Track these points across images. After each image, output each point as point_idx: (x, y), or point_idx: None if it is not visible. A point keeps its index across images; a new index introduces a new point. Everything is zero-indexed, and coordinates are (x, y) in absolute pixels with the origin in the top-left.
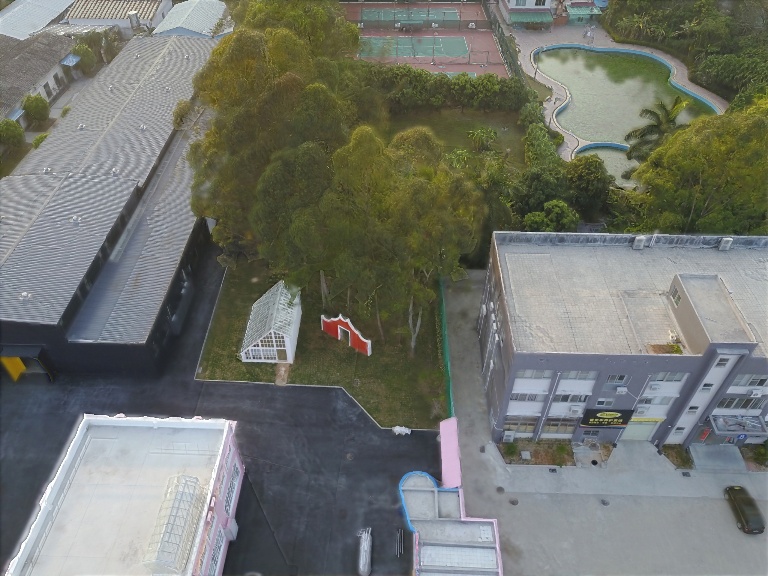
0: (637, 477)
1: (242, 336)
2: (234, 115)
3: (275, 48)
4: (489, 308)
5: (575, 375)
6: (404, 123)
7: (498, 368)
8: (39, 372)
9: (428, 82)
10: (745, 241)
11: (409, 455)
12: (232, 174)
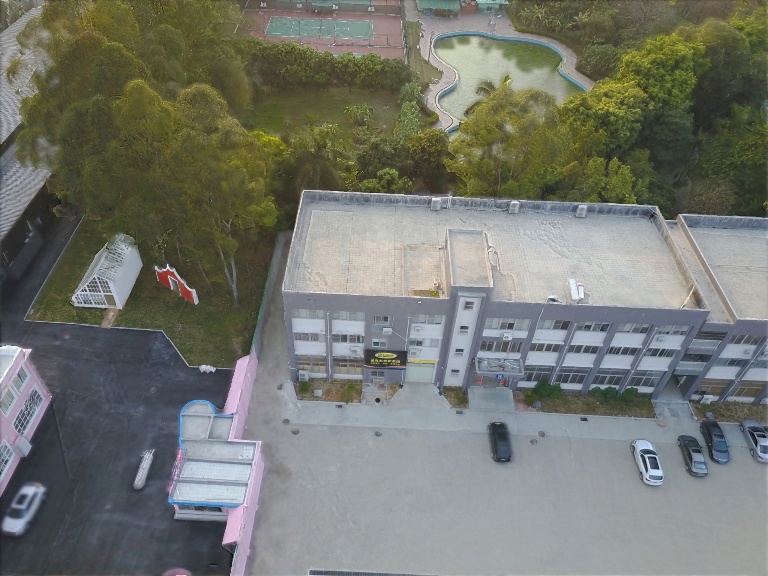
0: (414, 413)
1: None
2: (46, 70)
3: (99, 11)
4: None
5: (345, 316)
6: (292, 99)
7: None
8: None
9: (312, 59)
10: (533, 205)
11: (208, 390)
12: None
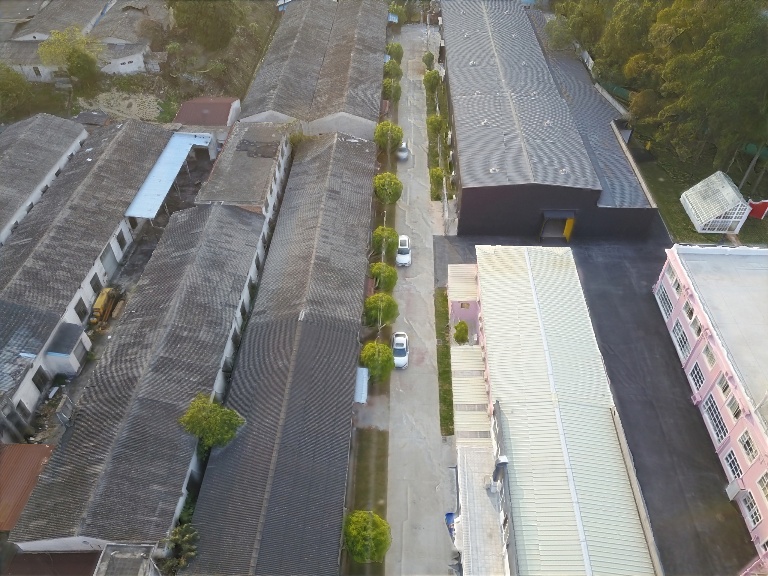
0: None
1: (684, 216)
2: (754, 27)
3: None
4: None
5: None
6: None
7: None
8: (552, 236)
9: None
10: None
11: None
12: (751, 72)
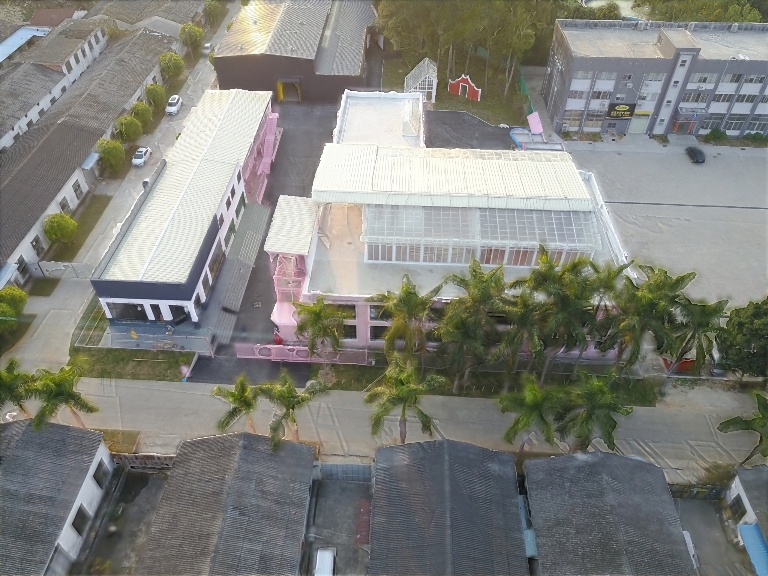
0: (637, 146)
1: (401, 92)
2: None
3: None
4: (552, 67)
5: (605, 77)
6: None
7: (560, 86)
8: (291, 100)
9: None
10: (702, 26)
11: None
12: None
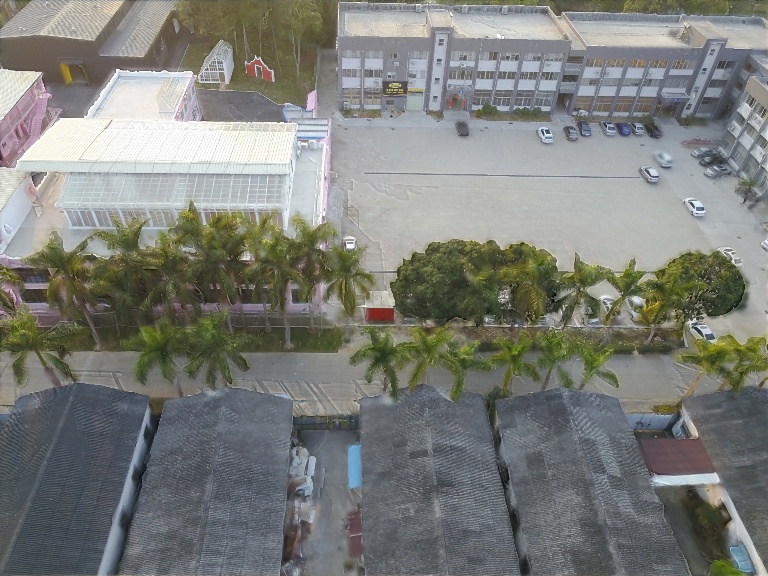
0: (413, 122)
1: None
2: None
3: None
4: None
5: (372, 55)
6: None
7: None
8: (80, 82)
9: None
10: (476, 8)
11: None
12: None
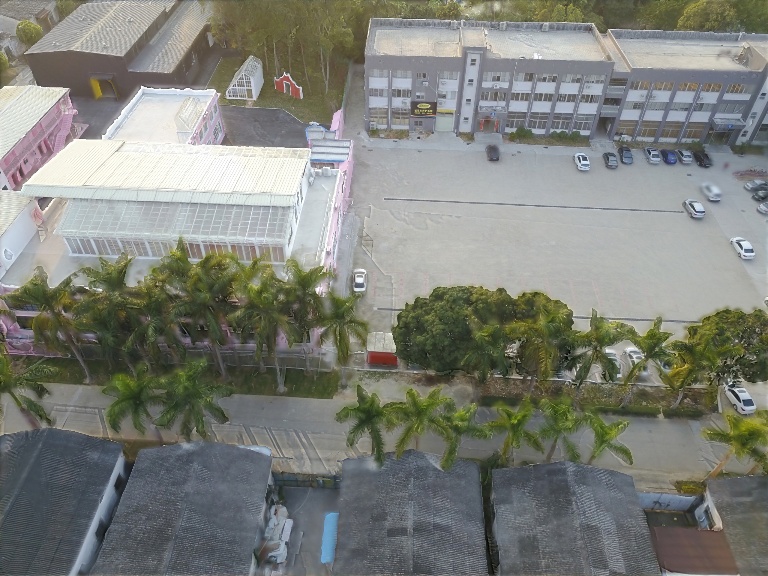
0: (441, 144)
1: None
2: None
3: None
4: None
5: (400, 75)
6: None
7: None
8: (110, 97)
9: None
10: (515, 25)
11: None
12: None
